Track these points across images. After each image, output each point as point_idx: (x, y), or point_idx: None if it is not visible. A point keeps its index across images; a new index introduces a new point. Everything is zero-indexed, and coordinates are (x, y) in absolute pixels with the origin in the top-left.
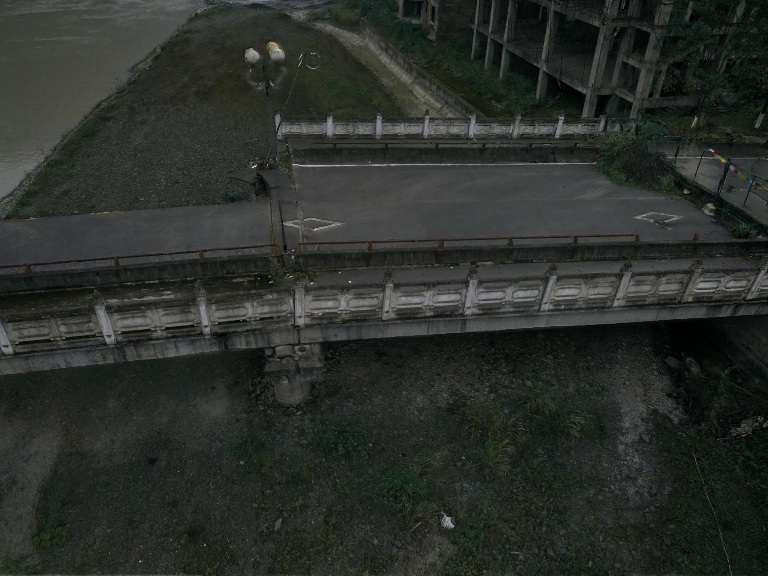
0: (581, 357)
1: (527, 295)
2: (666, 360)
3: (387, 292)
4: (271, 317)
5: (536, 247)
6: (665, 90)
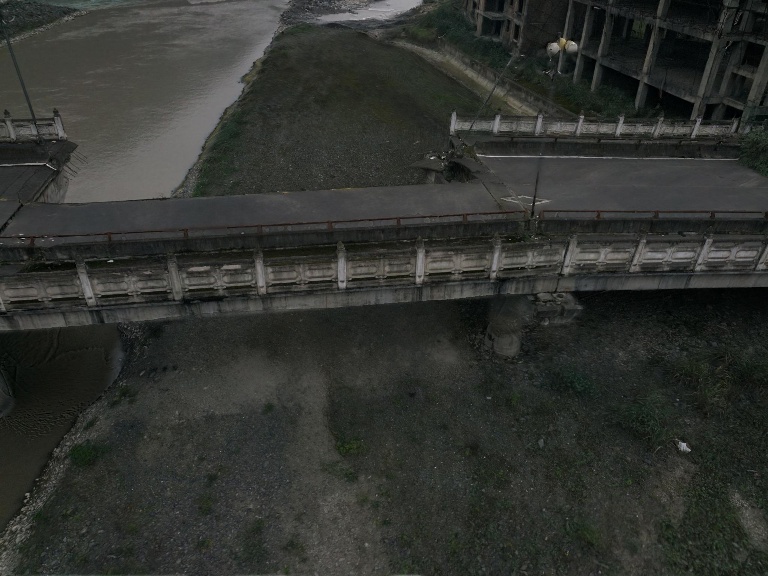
0: (750, 326)
1: (747, 255)
2: None
3: (639, 247)
4: (544, 266)
5: (734, 220)
6: None
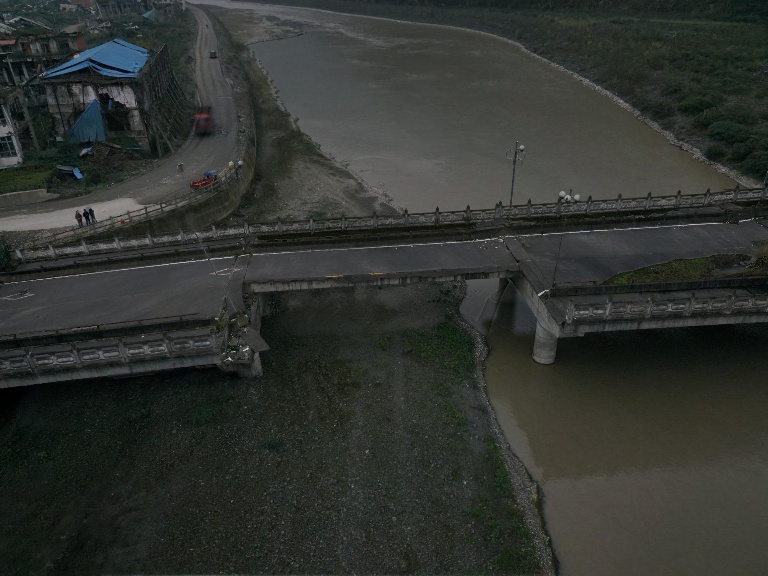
0: None
1: (159, 241)
2: None
3: None
4: None
5: None
6: None
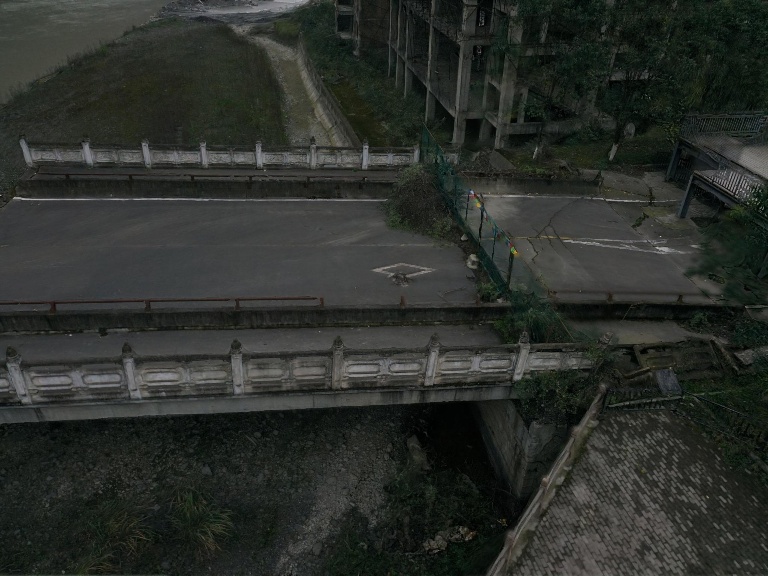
0: (302, 434)
1: (106, 380)
2: (408, 440)
3: None
4: None
5: (182, 312)
6: (530, 115)
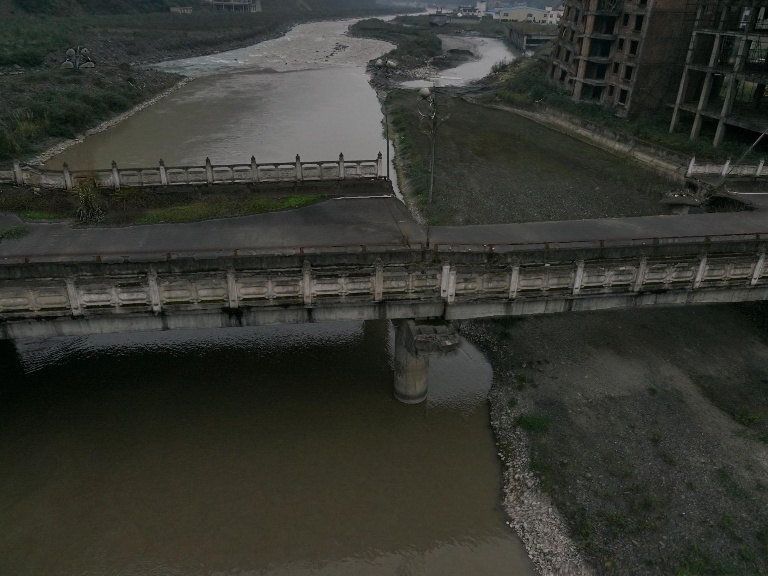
0: None
1: None
2: None
3: None
4: None
5: None
6: None
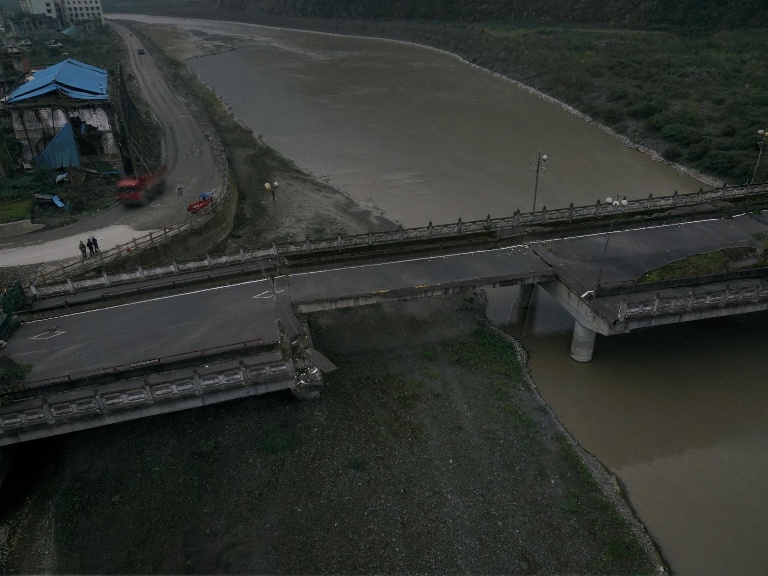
0: None
1: None
2: None
3: None
4: None
5: None
6: None
